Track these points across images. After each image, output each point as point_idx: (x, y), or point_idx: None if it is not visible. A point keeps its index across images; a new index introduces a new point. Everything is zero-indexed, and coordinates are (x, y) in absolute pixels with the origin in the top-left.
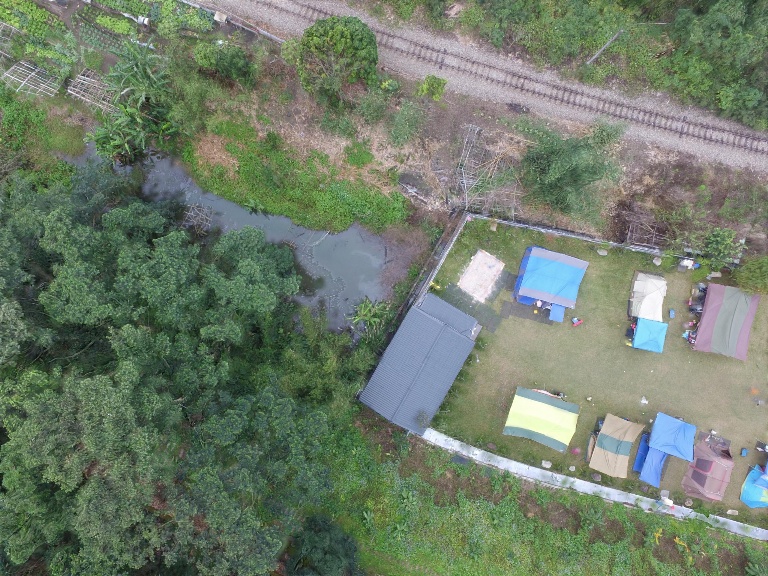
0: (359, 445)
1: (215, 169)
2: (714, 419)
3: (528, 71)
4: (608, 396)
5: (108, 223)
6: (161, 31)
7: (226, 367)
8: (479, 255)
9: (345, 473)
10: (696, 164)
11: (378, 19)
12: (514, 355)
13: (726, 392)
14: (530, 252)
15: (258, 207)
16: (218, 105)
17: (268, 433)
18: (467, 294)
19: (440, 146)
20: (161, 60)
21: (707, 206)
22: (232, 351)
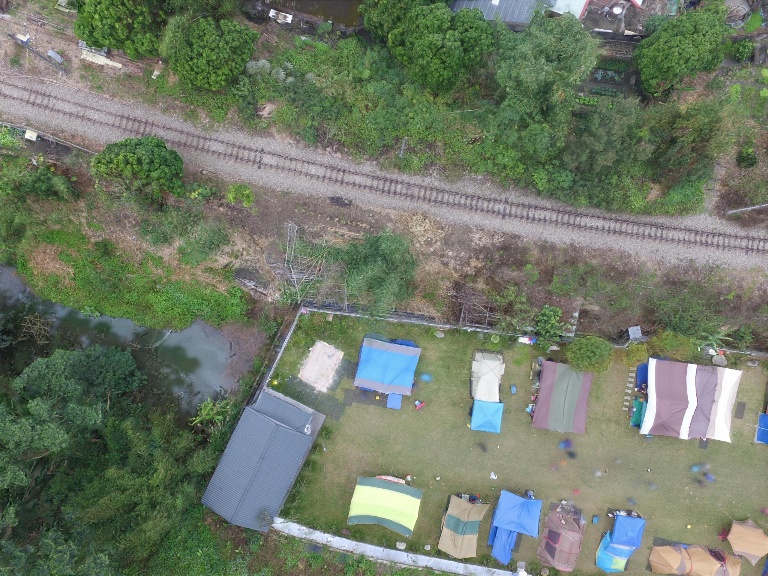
0: (205, 546)
1: (49, 279)
2: (564, 489)
3: (347, 164)
4: (457, 474)
5: None
6: None
7: (10, 515)
8: (318, 345)
9: None
10: (521, 244)
11: (193, 123)
12: (360, 441)
13: (573, 462)
14: None
15: (94, 314)
16: (47, 216)
17: None
18: (308, 385)
19: (269, 242)
20: None
21: (537, 283)
22: (71, 463)
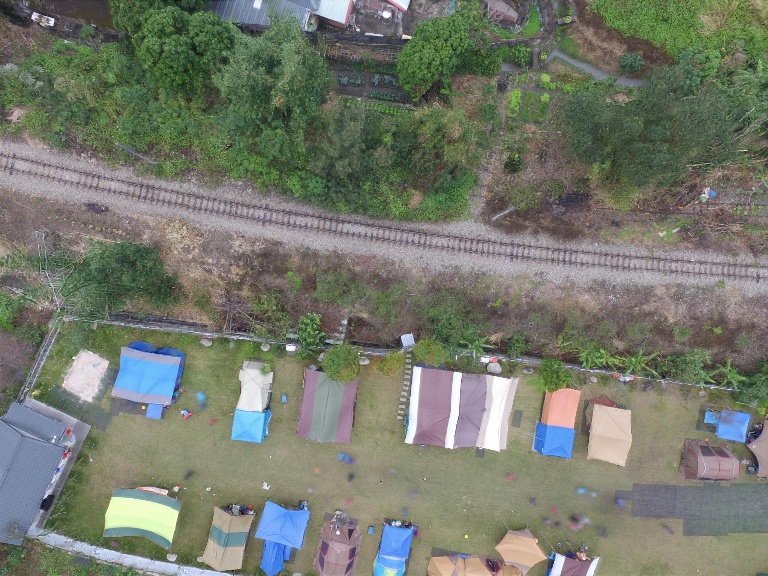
0: None
1: None
2: (339, 499)
3: (103, 170)
4: (228, 485)
5: None
6: None
7: None
8: (83, 354)
9: None
10: (283, 251)
11: None
12: (128, 451)
13: (348, 471)
14: None
15: None
16: None
17: None
18: (73, 394)
19: (28, 249)
20: None
21: (302, 290)
22: None
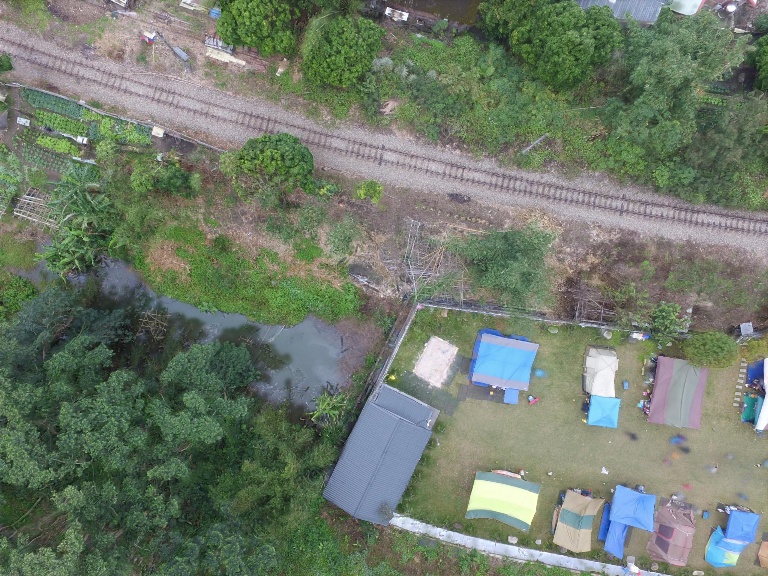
0: (325, 539)
1: (167, 275)
2: (674, 484)
3: (466, 161)
4: (568, 469)
5: (51, 370)
6: (99, 154)
7: (175, 506)
8: (432, 341)
9: (312, 571)
10: (638, 240)
11: (315, 120)
12: (473, 436)
13: (684, 457)
14: (481, 337)
15: (211, 309)
16: (165, 212)
17: (219, 572)
18: (423, 380)
19: (386, 238)
20: (99, 187)
21: (652, 279)
22: (194, 457)
